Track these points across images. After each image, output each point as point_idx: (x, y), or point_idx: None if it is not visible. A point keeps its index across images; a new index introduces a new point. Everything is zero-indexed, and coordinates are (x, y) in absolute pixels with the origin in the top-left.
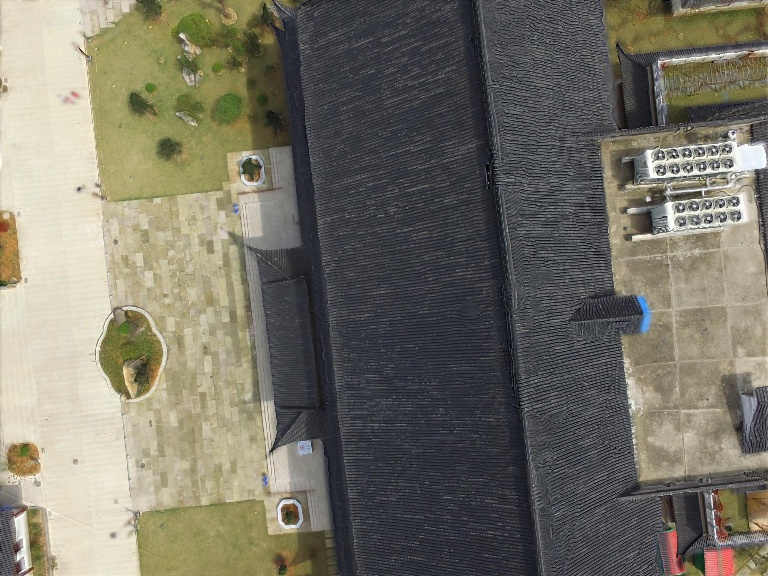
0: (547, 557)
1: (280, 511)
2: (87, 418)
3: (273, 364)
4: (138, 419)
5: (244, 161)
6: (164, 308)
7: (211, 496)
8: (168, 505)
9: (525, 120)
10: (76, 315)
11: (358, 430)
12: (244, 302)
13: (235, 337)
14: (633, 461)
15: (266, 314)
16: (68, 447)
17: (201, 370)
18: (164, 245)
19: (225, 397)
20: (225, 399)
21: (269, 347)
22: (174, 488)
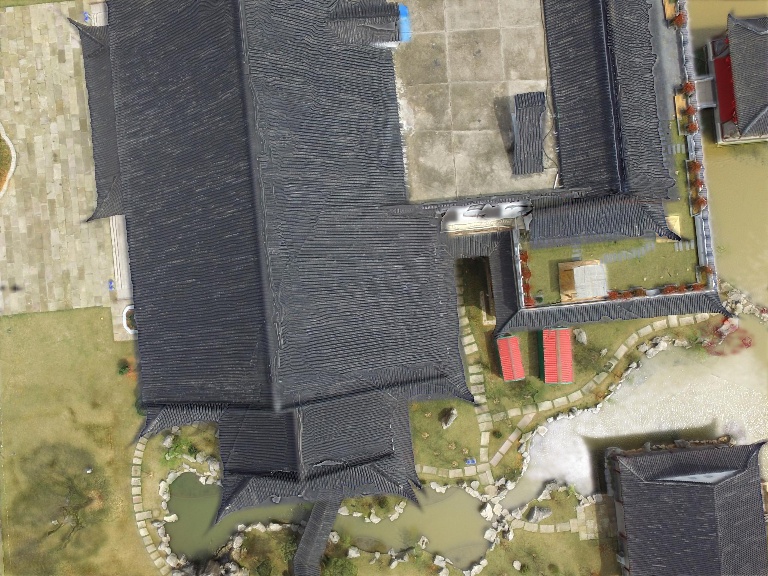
0: (271, 218)
1: (125, 316)
2: None
3: (94, 138)
4: None
5: None
6: (15, 116)
7: (58, 302)
8: (16, 310)
9: None
10: None
11: (132, 149)
12: None
13: (85, 145)
14: (403, 179)
15: (88, 88)
16: None
17: (50, 177)
18: (16, 54)
19: (74, 204)
20: (74, 206)
21: (91, 121)
22: (22, 294)
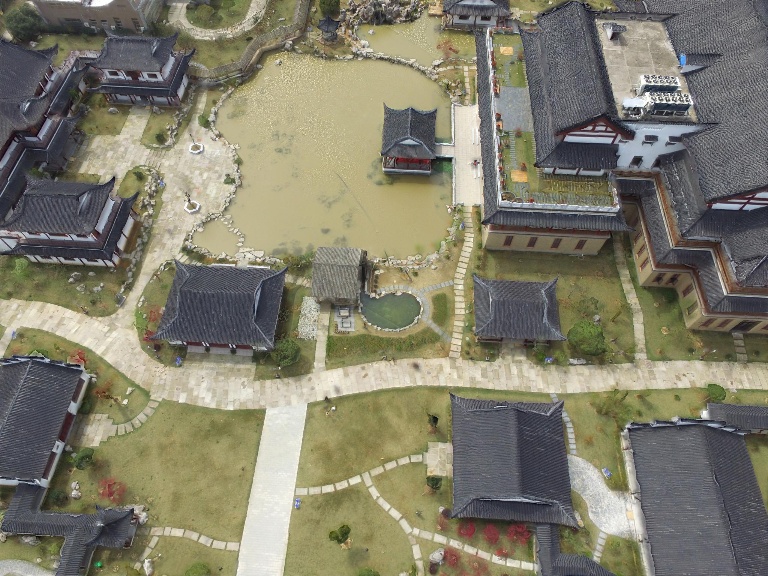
0: None
1: None
2: None
3: None
4: None
5: None
6: None
7: None
8: None
9: (767, 113)
10: None
11: None
12: None
13: None
14: None
15: None
16: None
17: None
18: None
19: None
20: None
21: None
22: None
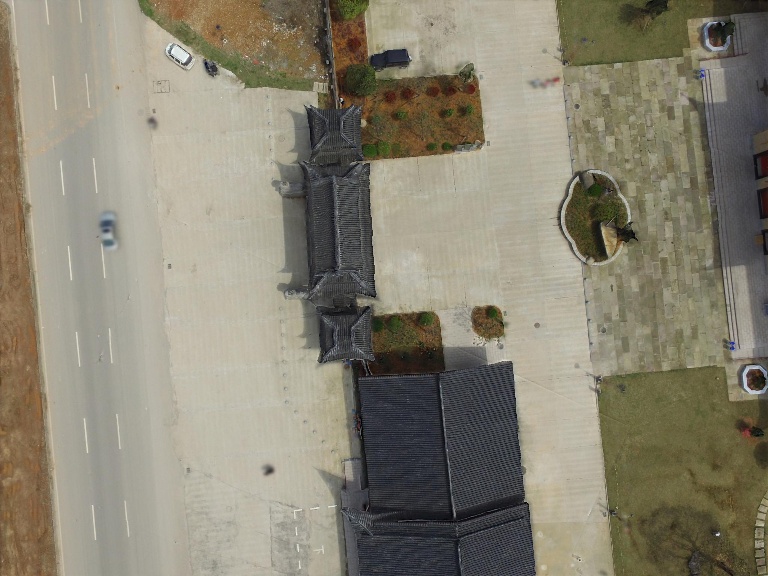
0: None
1: (746, 376)
2: (549, 282)
3: None
4: (599, 283)
5: (709, 26)
6: (625, 173)
7: (672, 362)
8: (629, 370)
9: None
10: (538, 179)
11: None
12: (705, 168)
13: (696, 203)
14: None
15: None
16: (530, 310)
17: (662, 235)
18: (625, 110)
19: (686, 263)
20: (686, 265)
21: None
22: (635, 353)
